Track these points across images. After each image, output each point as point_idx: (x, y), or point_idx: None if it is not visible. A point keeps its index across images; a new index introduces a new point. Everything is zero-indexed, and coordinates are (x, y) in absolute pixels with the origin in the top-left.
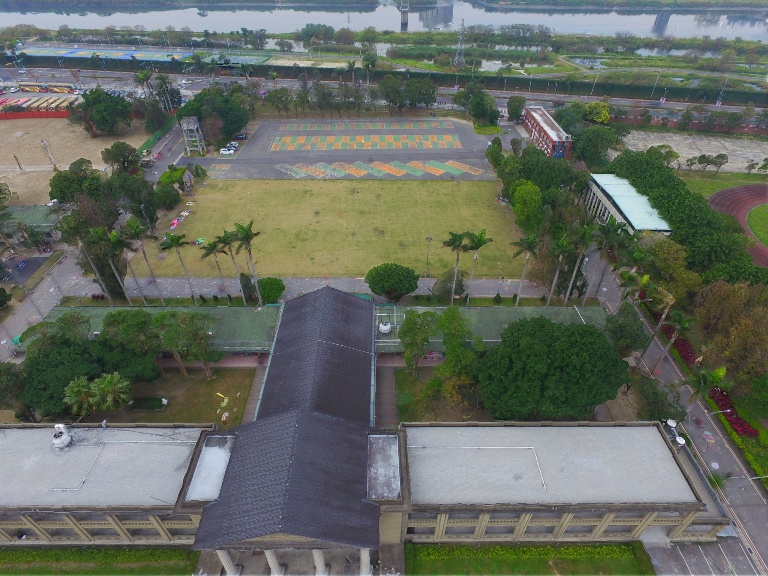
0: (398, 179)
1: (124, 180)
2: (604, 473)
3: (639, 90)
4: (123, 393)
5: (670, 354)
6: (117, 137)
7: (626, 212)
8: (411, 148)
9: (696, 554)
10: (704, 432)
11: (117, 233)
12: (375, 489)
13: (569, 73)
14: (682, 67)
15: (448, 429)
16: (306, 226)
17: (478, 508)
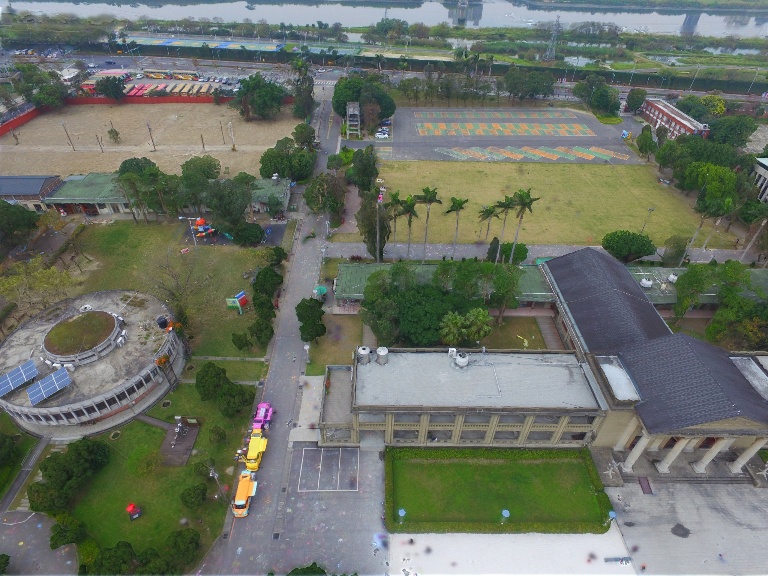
0: (556, 162)
1: (360, 155)
2: None
3: (737, 85)
4: None
5: None
6: (270, 121)
7: None
8: (550, 135)
9: None
10: None
11: None
12: (761, 395)
13: (663, 69)
14: (757, 65)
15: None
16: None
17: None
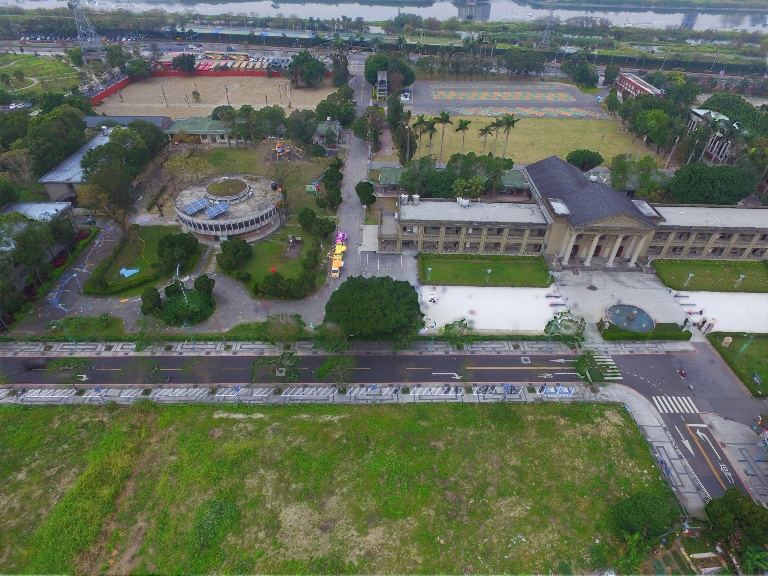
0: (542, 117)
1: (394, 99)
2: (751, 222)
3: (701, 66)
4: None
5: None
6: (314, 89)
7: None
8: (539, 100)
9: None
10: None
11: None
12: None
13: (641, 53)
14: (728, 53)
15: (661, 207)
16: None
17: (692, 229)
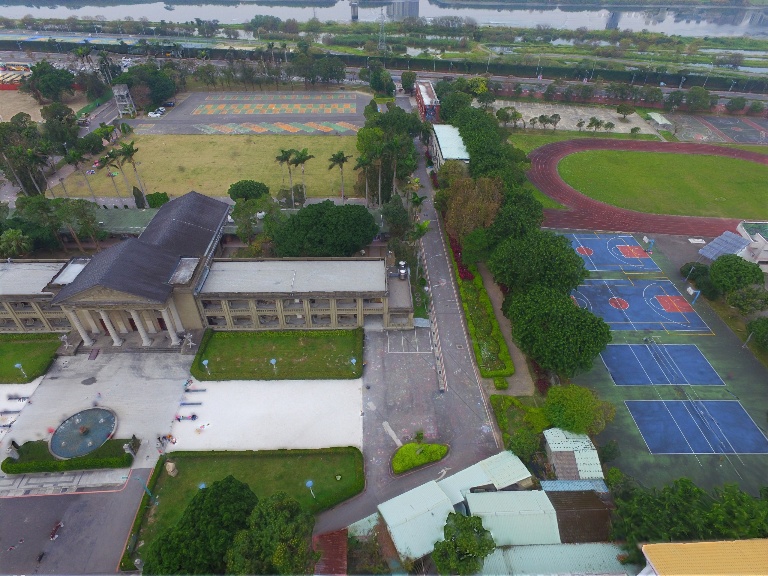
0: (292, 134)
1: (49, 123)
2: (335, 281)
3: (526, 70)
4: (24, 242)
5: (444, 240)
6: None
7: (442, 148)
8: (313, 113)
9: (397, 335)
10: (441, 279)
11: (33, 150)
12: (174, 281)
13: (472, 56)
14: (582, 54)
15: (244, 262)
16: (203, 165)
17: (244, 296)
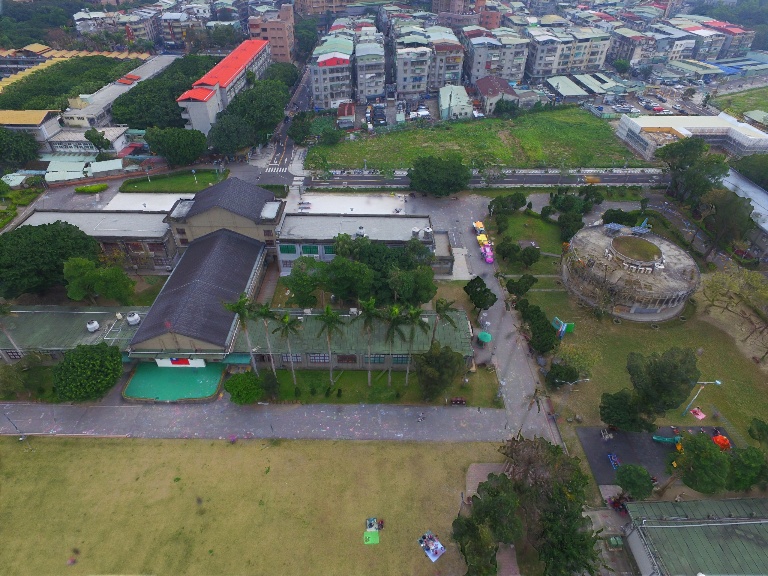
0: None
1: None
2: (67, 221)
3: None
4: None
5: None
6: None
7: None
8: None
9: None
10: None
11: (394, 315)
12: None
13: None
14: None
15: None
16: None
17: None
